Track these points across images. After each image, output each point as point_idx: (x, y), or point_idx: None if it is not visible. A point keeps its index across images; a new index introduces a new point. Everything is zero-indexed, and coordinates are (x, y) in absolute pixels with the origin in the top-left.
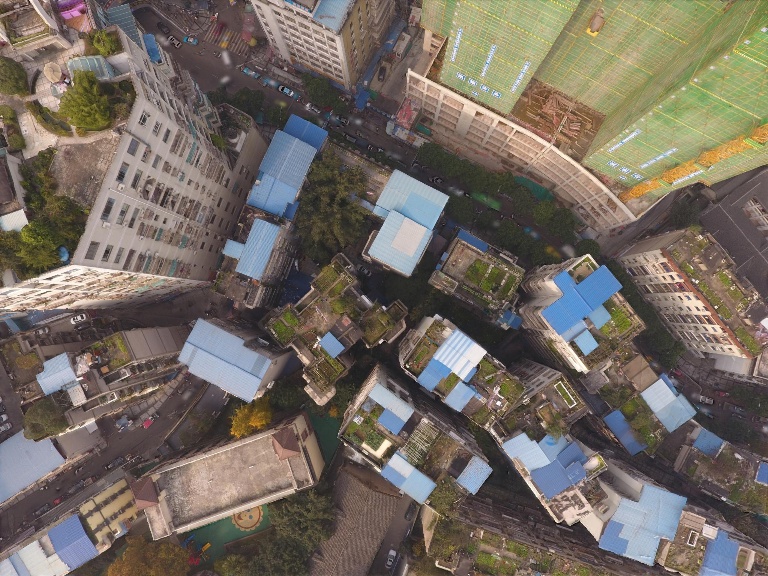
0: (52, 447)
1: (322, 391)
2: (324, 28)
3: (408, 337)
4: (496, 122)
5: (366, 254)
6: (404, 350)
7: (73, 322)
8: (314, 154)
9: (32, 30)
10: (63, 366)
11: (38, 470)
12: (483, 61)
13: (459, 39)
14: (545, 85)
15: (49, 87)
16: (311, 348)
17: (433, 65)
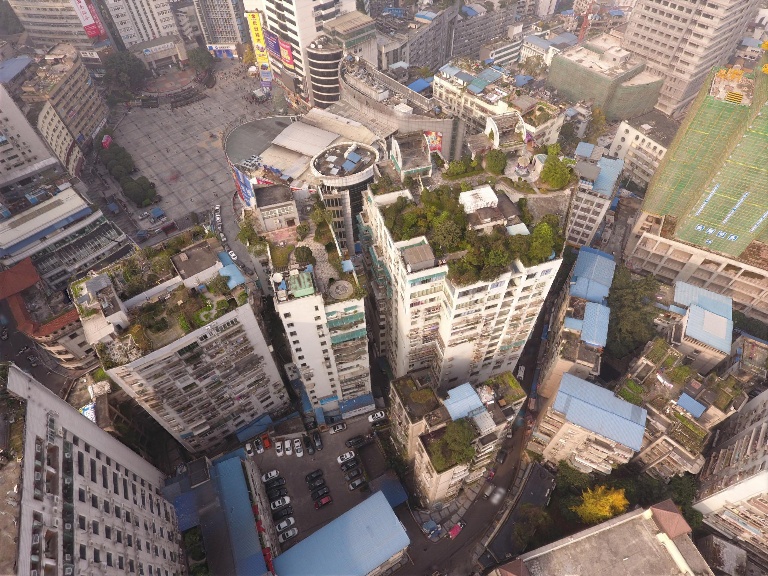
0: (397, 522)
1: (696, 453)
2: (598, 197)
3: (738, 421)
4: (723, 266)
5: (676, 341)
6: (763, 414)
7: (371, 419)
8: (615, 265)
9: (510, 142)
10: (469, 393)
11: (379, 552)
12: (730, 209)
13: (713, 194)
14: (753, 242)
15: (513, 172)
16: (665, 413)
17: (662, 230)
